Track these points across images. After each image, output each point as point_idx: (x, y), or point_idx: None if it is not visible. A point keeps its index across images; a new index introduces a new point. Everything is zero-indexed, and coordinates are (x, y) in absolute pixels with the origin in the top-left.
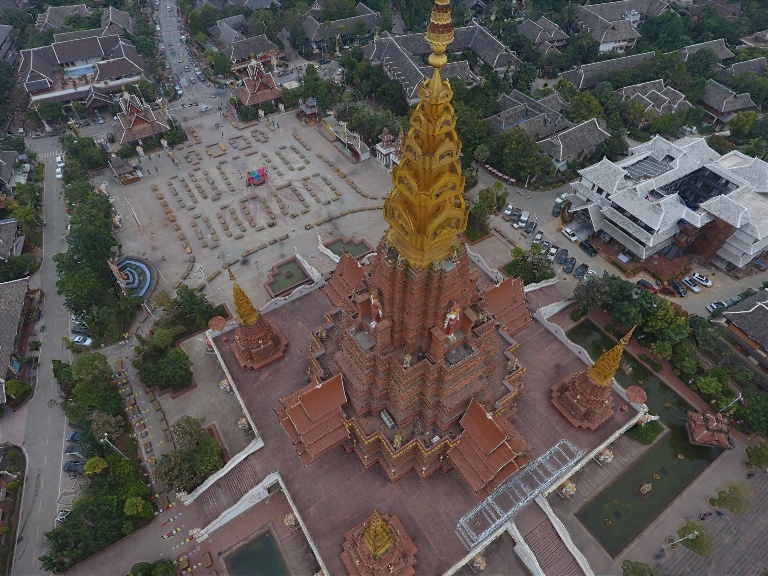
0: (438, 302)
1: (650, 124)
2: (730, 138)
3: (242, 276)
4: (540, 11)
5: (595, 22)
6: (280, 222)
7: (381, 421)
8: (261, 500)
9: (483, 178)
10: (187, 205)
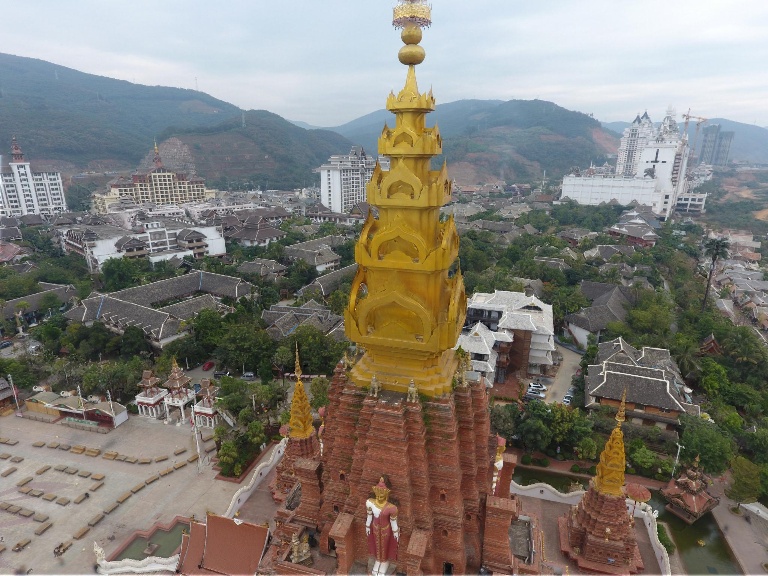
0: (477, 448)
1: None
2: None
3: None
4: (250, 256)
5: (302, 254)
6: None
7: None
8: None
9: None
10: None
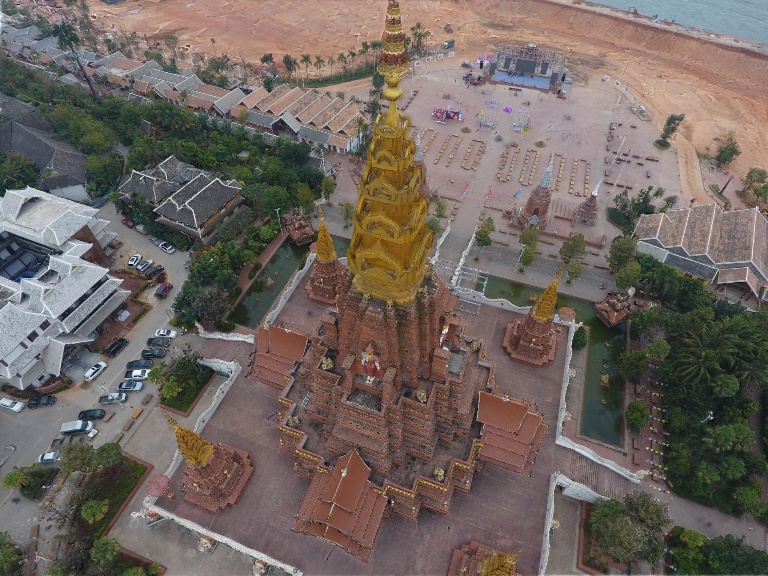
0: None
1: None
2: None
3: None
4: None
5: None
6: None
7: None
8: None
9: None
10: None
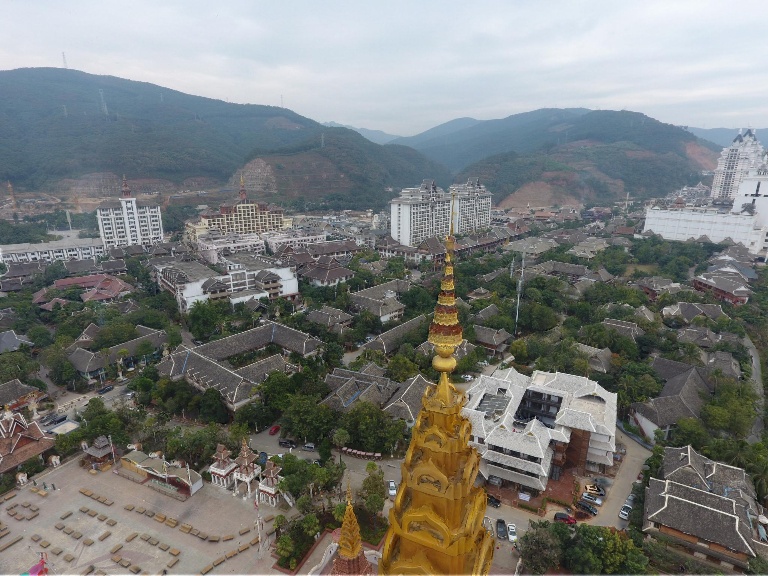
0: None
1: (456, 367)
2: (517, 362)
3: None
4: (319, 302)
5: (368, 303)
6: None
7: None
8: None
9: (346, 463)
10: None
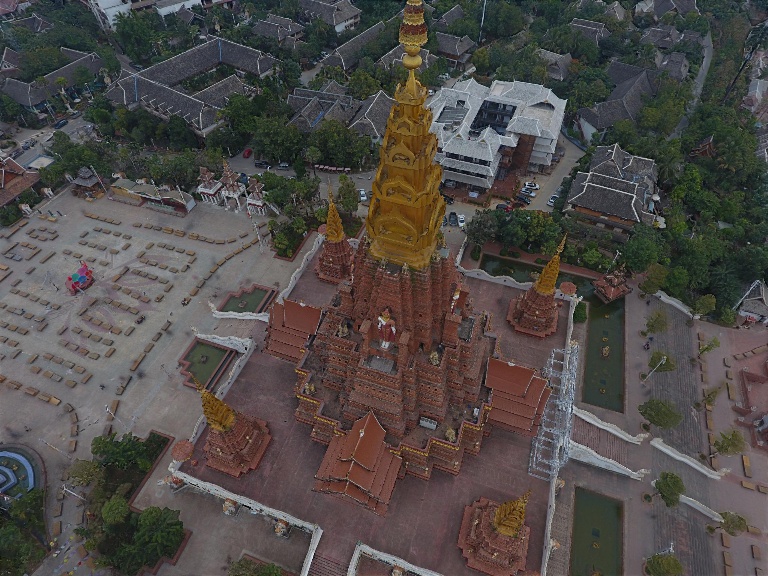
0: (443, 290)
1: None
2: (478, 73)
3: (149, 391)
4: (263, 10)
5: (319, 8)
6: (148, 313)
7: (422, 429)
8: None
9: (320, 178)
10: (7, 353)
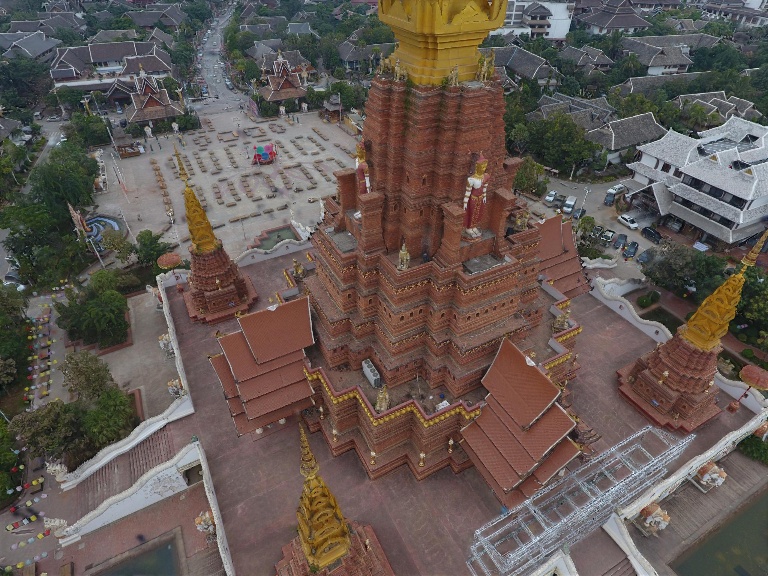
0: (455, 155)
1: None
2: None
3: (224, 239)
4: (582, 43)
5: (642, 49)
6: (281, 195)
7: (362, 377)
8: (174, 493)
9: None
10: None
